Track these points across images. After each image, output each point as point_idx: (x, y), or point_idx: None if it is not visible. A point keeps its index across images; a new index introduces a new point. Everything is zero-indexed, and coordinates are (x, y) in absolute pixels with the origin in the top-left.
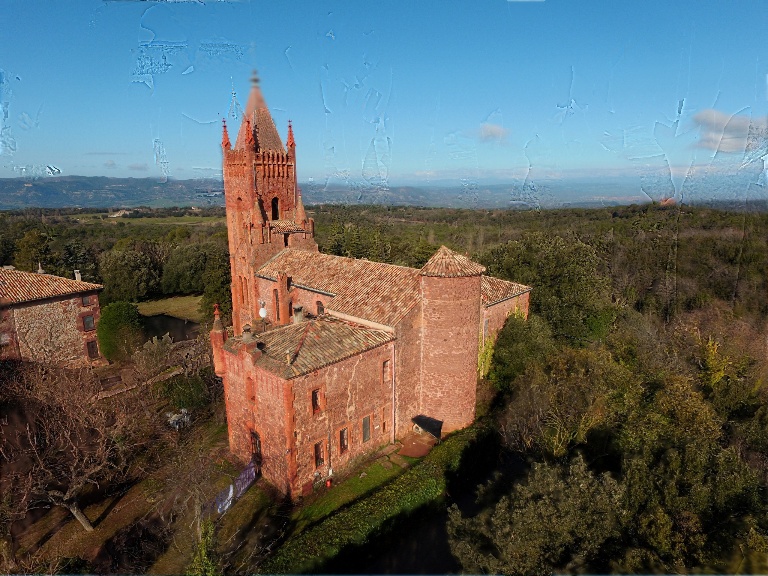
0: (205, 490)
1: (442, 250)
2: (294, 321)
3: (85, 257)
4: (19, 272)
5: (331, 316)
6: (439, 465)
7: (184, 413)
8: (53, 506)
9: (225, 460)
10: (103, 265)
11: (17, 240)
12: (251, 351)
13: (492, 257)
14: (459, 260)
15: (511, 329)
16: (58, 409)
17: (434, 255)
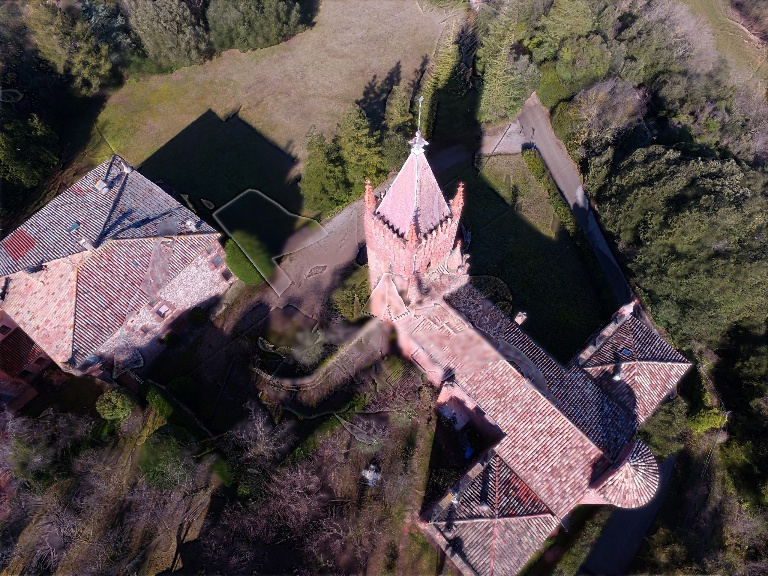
0: (415, 567)
1: (625, 470)
2: (480, 508)
3: (106, 8)
4: (137, 240)
5: (502, 464)
6: (568, 575)
7: (373, 468)
8: (329, 573)
9: (418, 531)
10: (135, 24)
11: (24, 17)
12: (459, 567)
13: (660, 202)
14: (638, 484)
15: (652, 425)
16: (304, 516)
17: (615, 474)
